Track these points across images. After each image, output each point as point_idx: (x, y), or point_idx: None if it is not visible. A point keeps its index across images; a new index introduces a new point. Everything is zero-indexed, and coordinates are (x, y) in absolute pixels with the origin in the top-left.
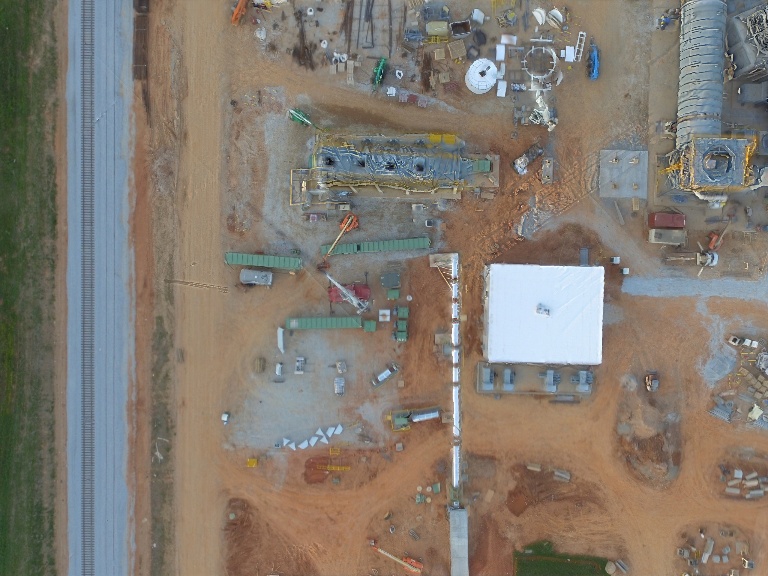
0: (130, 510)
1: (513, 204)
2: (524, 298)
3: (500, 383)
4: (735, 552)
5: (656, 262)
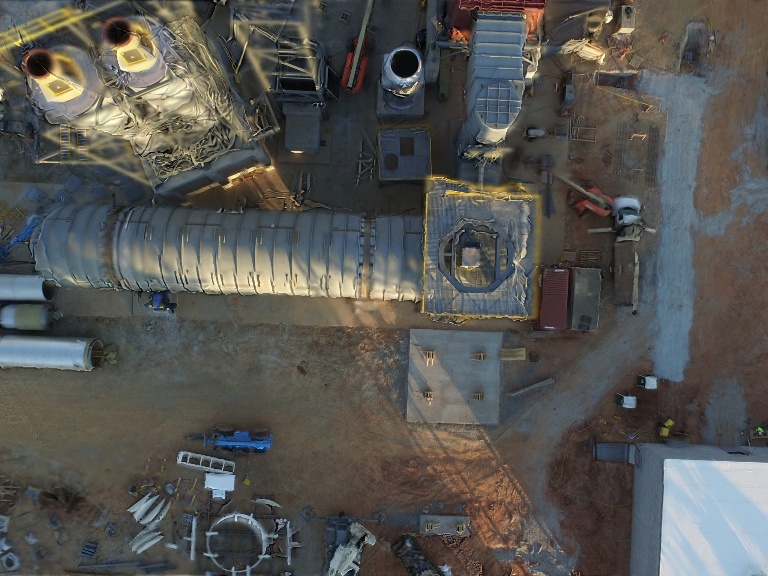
0: None
1: None
2: None
3: None
4: None
5: (626, 314)
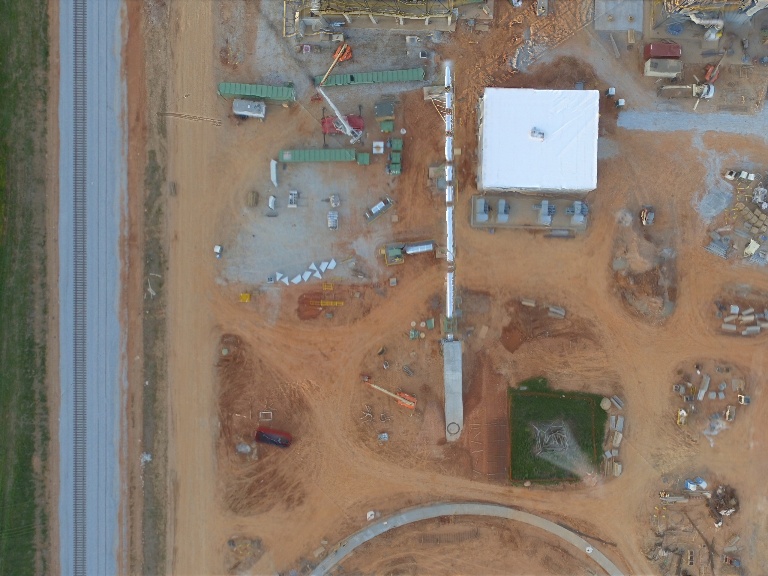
0: (122, 347)
1: (508, 37)
2: (518, 122)
3: (494, 216)
4: (731, 389)
5: (652, 96)
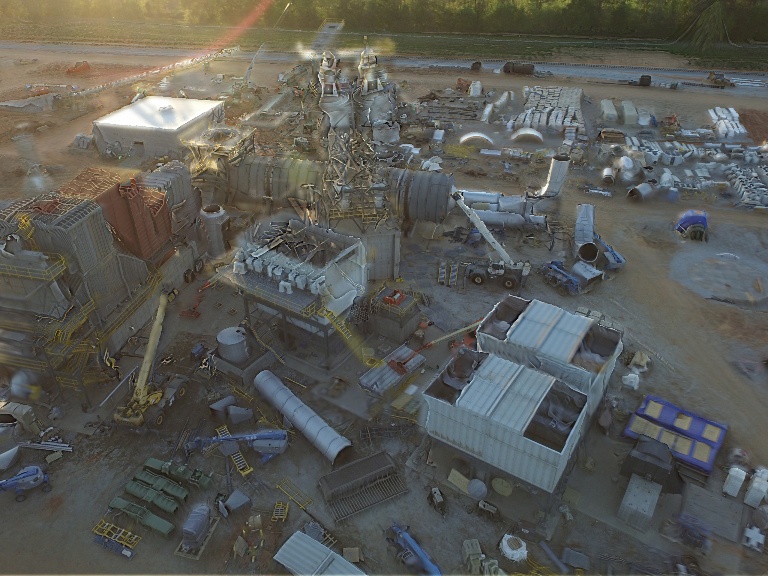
0: None
1: None
2: None
3: None
4: None
5: None
